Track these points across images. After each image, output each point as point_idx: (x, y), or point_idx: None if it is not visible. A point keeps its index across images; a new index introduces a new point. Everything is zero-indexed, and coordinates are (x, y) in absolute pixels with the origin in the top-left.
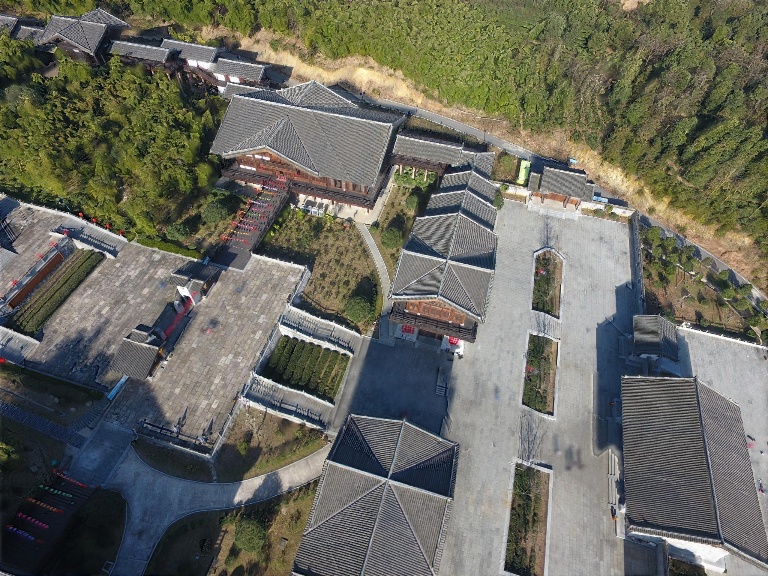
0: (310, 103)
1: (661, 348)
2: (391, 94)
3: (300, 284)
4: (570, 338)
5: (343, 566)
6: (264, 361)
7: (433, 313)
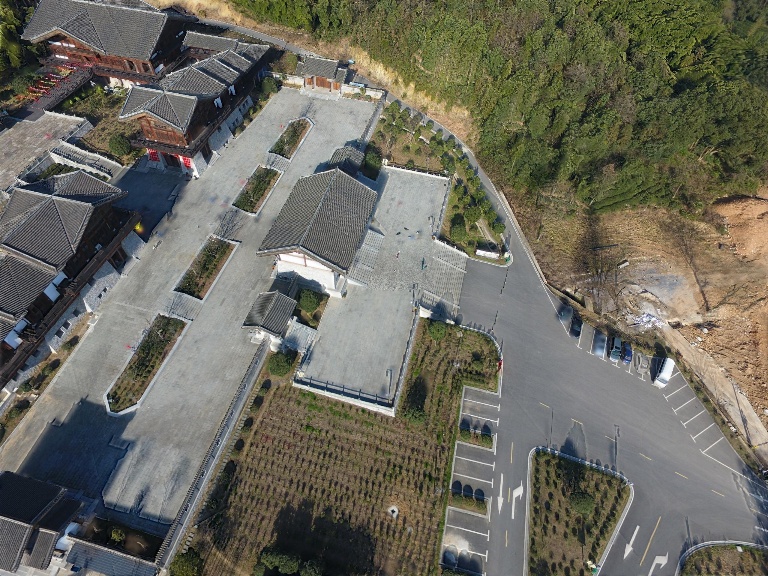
0: (112, 3)
1: (340, 164)
2: (216, 15)
3: (78, 130)
4: (294, 171)
5: (3, 237)
6: (33, 176)
7: (165, 138)
